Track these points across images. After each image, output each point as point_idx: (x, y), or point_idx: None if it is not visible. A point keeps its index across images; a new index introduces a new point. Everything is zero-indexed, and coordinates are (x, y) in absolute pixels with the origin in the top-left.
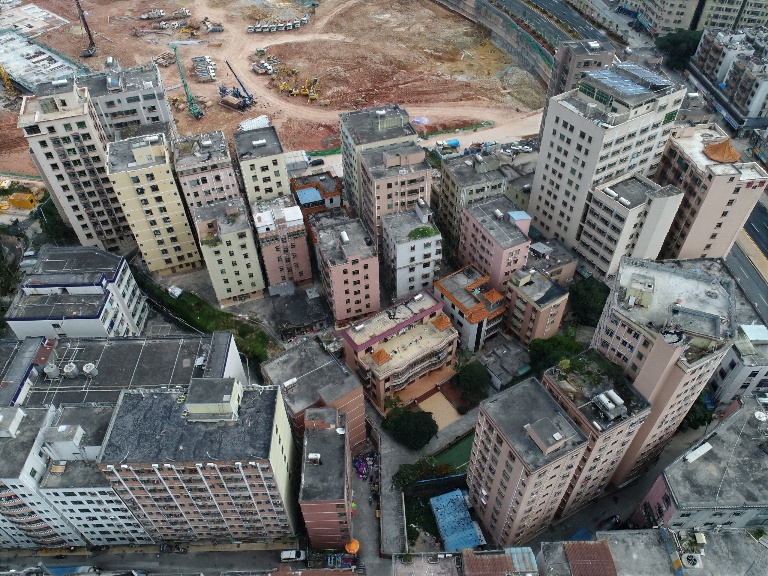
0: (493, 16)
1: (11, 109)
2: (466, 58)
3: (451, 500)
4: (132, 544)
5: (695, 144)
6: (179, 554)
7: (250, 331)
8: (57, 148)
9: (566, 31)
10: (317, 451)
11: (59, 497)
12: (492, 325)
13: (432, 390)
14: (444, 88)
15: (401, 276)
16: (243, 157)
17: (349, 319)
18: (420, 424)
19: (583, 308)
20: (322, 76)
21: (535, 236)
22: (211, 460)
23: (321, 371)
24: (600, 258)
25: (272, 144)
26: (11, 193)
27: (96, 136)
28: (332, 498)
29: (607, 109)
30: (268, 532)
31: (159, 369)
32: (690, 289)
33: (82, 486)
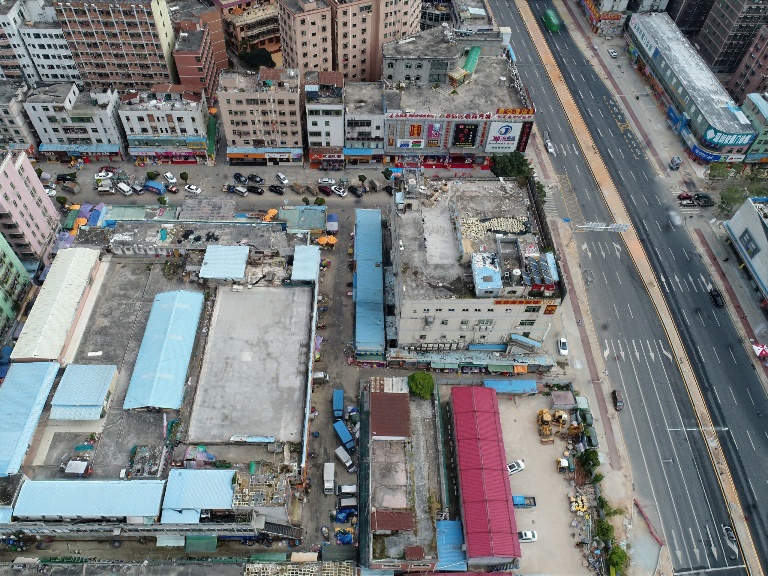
0: None
1: None
2: None
3: None
4: None
5: None
6: None
7: None
8: None
9: None
10: None
11: (31, 39)
12: None
13: (276, 50)
14: None
15: None
16: None
17: None
18: (260, 50)
19: None
20: None
21: None
22: None
23: None
24: None
25: None
26: None
27: None
28: None
29: None
30: None
31: None
32: None
33: None
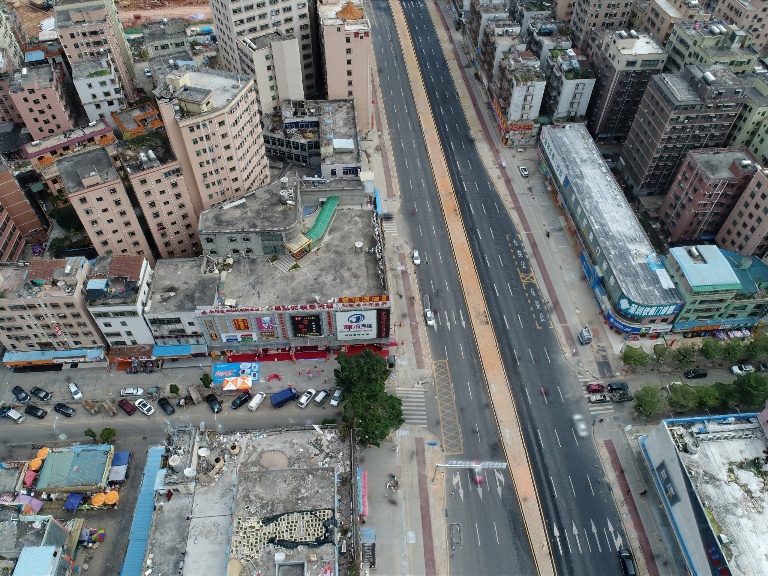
0: None
1: None
2: None
3: (92, 263)
4: None
5: (336, 9)
6: None
7: None
8: None
9: None
10: None
11: None
12: None
13: None
14: None
15: (90, 112)
16: None
17: None
18: (72, 209)
19: None
20: None
21: None
22: None
23: None
24: None
25: None
26: None
27: None
28: None
29: None
30: None
31: None
32: (223, 84)
33: None
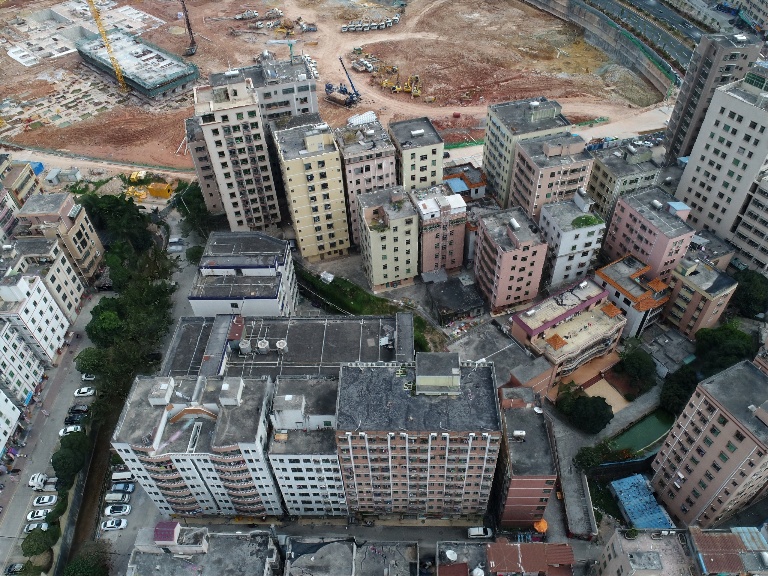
0: (588, 14)
1: (125, 105)
2: (562, 56)
3: (633, 484)
4: (324, 515)
5: None
6: (366, 527)
7: None
8: (227, 136)
9: (666, 29)
10: (517, 429)
11: (283, 464)
12: (653, 314)
13: (596, 377)
14: (546, 85)
15: (559, 264)
16: (403, 146)
17: (505, 306)
18: (599, 408)
19: (745, 299)
20: (421, 74)
21: None
22: (443, 430)
23: (504, 353)
24: (760, 250)
25: (429, 134)
26: (147, 183)
27: (261, 125)
28: (543, 474)
29: None
30: (463, 507)
31: (346, 348)
32: None
33: (308, 453)
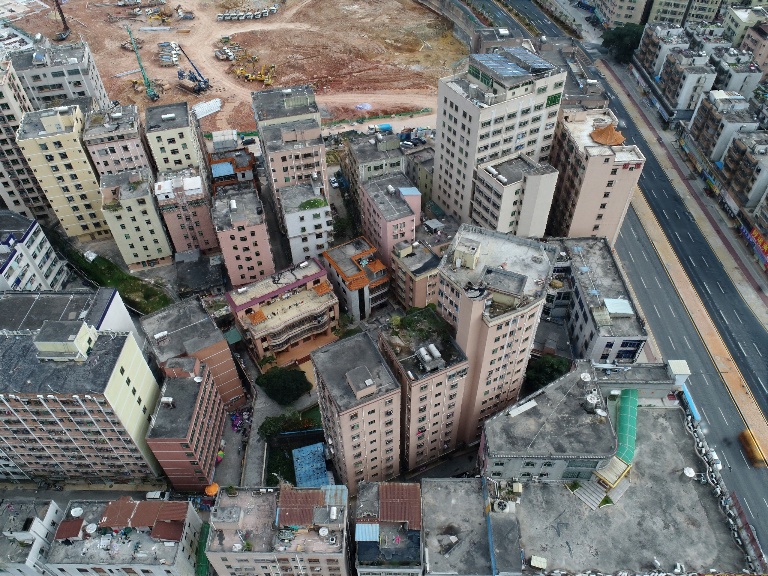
0: (455, 8)
1: None
2: (425, 49)
3: (311, 452)
4: (11, 479)
5: (585, 128)
6: (55, 491)
7: (154, 294)
8: None
9: (523, 24)
10: (173, 396)
11: None
12: (377, 294)
13: None
14: (396, 77)
15: (295, 246)
16: (151, 129)
17: None
18: (288, 380)
19: None
20: (281, 63)
21: (438, 214)
22: (53, 393)
23: (195, 327)
24: None
25: (181, 118)
26: None
27: (16, 106)
28: (177, 437)
29: (490, 90)
30: (131, 471)
31: None
32: (519, 254)
33: None
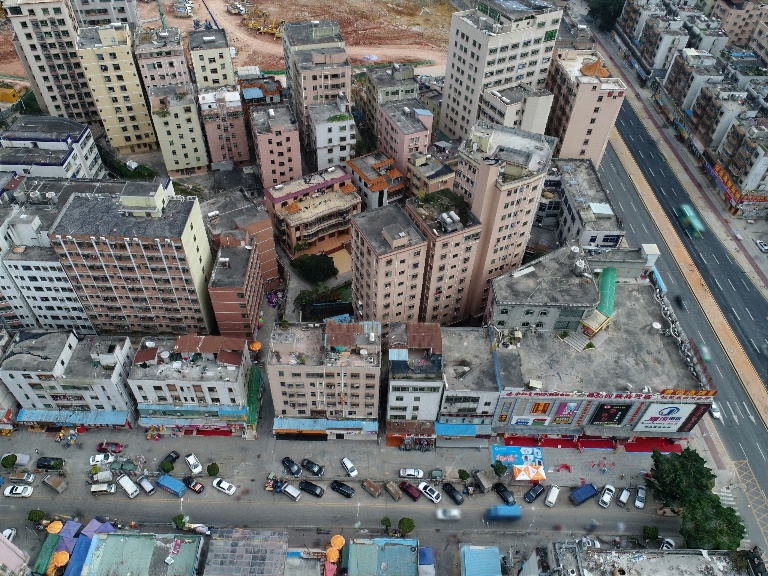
0: None
1: (1, 29)
2: (424, 14)
3: (340, 320)
4: None
5: (576, 64)
6: None
7: None
8: (36, 30)
9: None
10: None
11: (18, 271)
12: (393, 199)
13: (338, 247)
14: (399, 36)
15: (321, 156)
16: (194, 49)
17: None
18: (320, 261)
19: None
20: (290, 19)
21: None
22: None
23: (241, 211)
24: None
25: (220, 41)
26: None
27: (70, 23)
28: None
29: None
30: (187, 326)
31: None
32: (524, 144)
33: (37, 261)
